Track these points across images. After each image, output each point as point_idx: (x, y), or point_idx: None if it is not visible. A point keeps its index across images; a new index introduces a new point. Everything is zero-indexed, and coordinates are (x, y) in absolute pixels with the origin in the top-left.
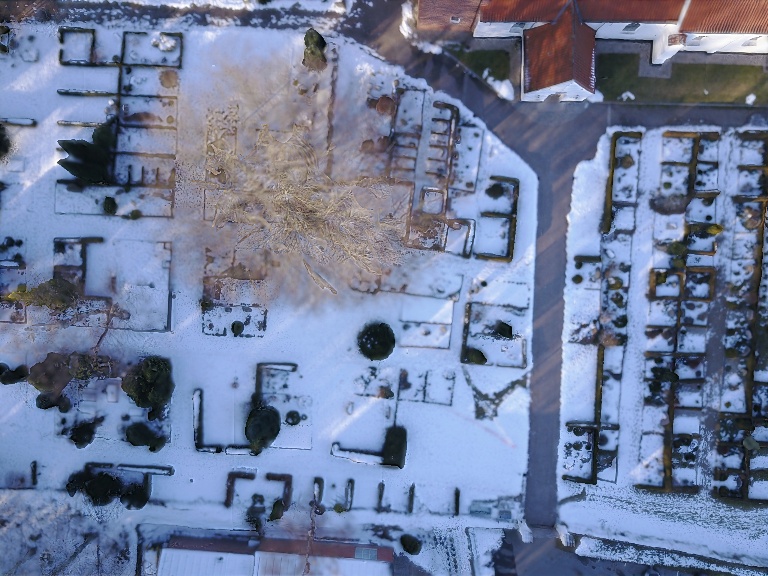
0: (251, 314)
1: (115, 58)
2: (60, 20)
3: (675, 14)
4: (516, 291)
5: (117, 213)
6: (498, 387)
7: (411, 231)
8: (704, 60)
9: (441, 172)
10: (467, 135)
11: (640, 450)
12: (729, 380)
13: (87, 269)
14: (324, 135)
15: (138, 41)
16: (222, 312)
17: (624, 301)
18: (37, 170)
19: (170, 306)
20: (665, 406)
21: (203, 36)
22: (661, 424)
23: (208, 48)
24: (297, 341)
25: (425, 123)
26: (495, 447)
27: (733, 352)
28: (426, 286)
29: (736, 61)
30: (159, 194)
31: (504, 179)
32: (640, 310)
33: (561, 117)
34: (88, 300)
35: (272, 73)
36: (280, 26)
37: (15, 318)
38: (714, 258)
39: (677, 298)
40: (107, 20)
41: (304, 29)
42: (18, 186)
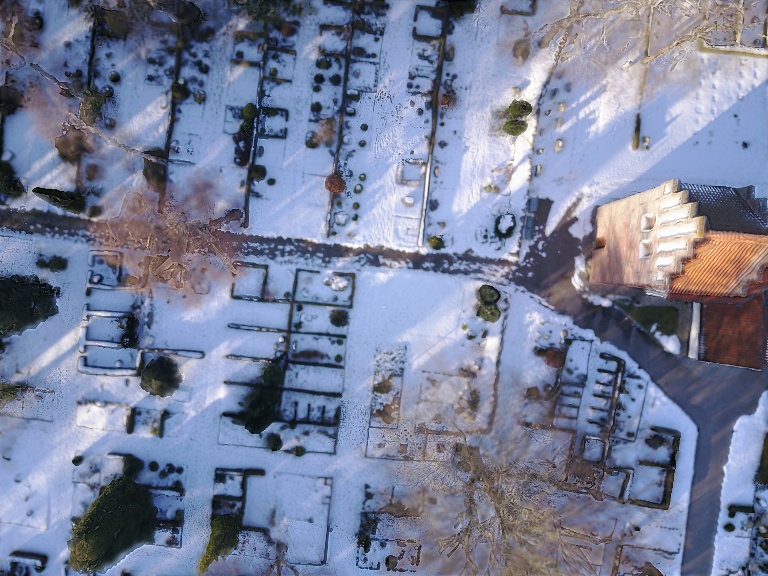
0: (405, 549)
1: (288, 296)
2: (233, 253)
3: None
4: (668, 536)
5: (281, 448)
6: None
7: (569, 476)
8: None
9: (604, 423)
10: (631, 386)
11: None
12: None
13: (247, 500)
14: (491, 382)
15: (311, 280)
16: (377, 546)
17: None
18: (203, 401)
19: (327, 540)
20: None
21: (375, 277)
22: None
23: (379, 289)
24: (448, 575)
25: (590, 372)
26: None
27: None
28: (580, 528)
29: None
30: (324, 432)
31: (666, 432)
32: None
33: (726, 373)
34: (246, 530)
35: (441, 317)
36: (452, 271)
37: (171, 543)
38: None
39: None
40: (280, 256)
41: (476, 275)
42: (183, 415)
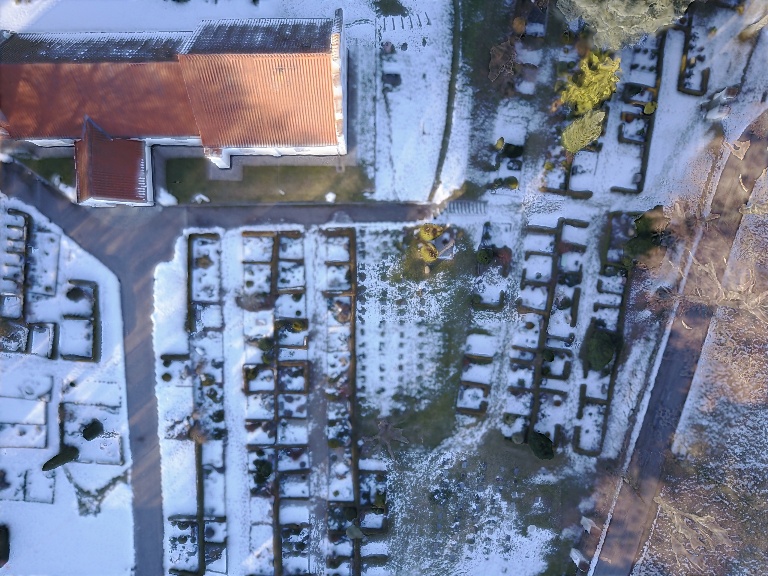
0: None
1: None
2: None
3: (195, 130)
4: (107, 390)
5: None
6: (99, 484)
7: None
8: (275, 162)
9: (17, 278)
10: (44, 240)
11: (250, 541)
12: (336, 469)
13: None
14: None
15: None
16: None
17: (218, 397)
18: None
19: None
20: (271, 497)
21: None
22: (269, 515)
23: None
24: None
25: (2, 230)
26: (101, 543)
27: (332, 443)
28: (16, 388)
29: (308, 162)
30: None
31: (80, 283)
32: (238, 404)
33: (135, 221)
34: None
35: None
36: None
37: None
38: (309, 351)
39: (272, 392)
40: None
41: None
42: None
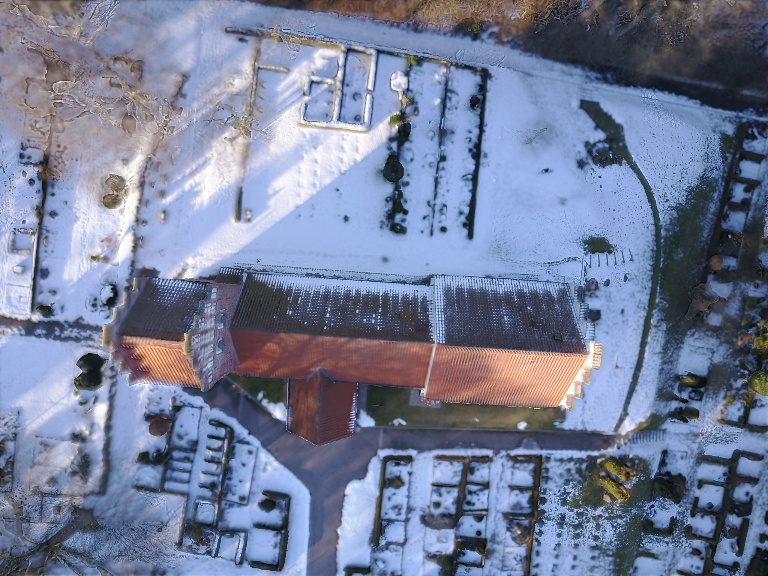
0: None
1: None
2: None
3: (420, 384)
4: None
5: None
6: None
7: (185, 538)
8: None
9: (213, 487)
10: (241, 451)
11: None
12: None
13: None
14: (100, 447)
15: None
16: None
17: None
18: None
19: None
20: None
21: None
22: None
23: None
24: None
25: (201, 437)
26: None
27: None
28: None
29: None
30: None
31: (274, 497)
32: None
33: None
34: None
35: (54, 383)
36: (63, 339)
37: None
38: (484, 569)
39: None
40: None
41: (86, 343)
42: None
